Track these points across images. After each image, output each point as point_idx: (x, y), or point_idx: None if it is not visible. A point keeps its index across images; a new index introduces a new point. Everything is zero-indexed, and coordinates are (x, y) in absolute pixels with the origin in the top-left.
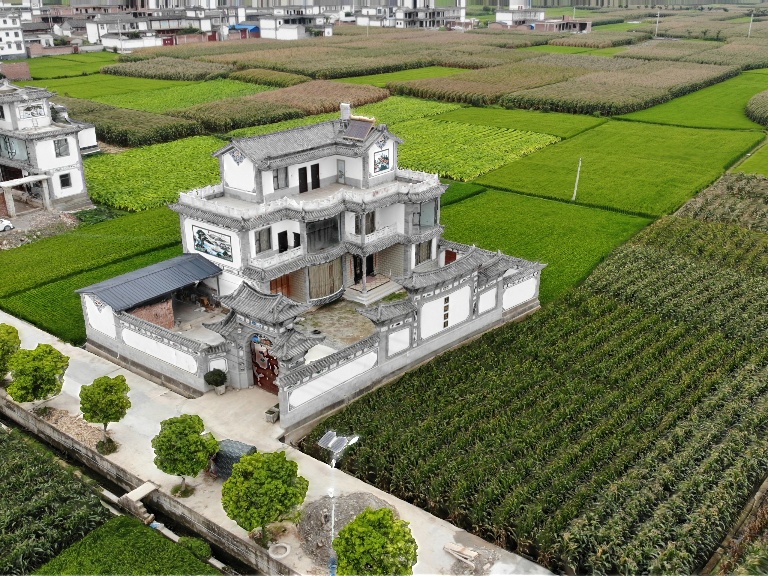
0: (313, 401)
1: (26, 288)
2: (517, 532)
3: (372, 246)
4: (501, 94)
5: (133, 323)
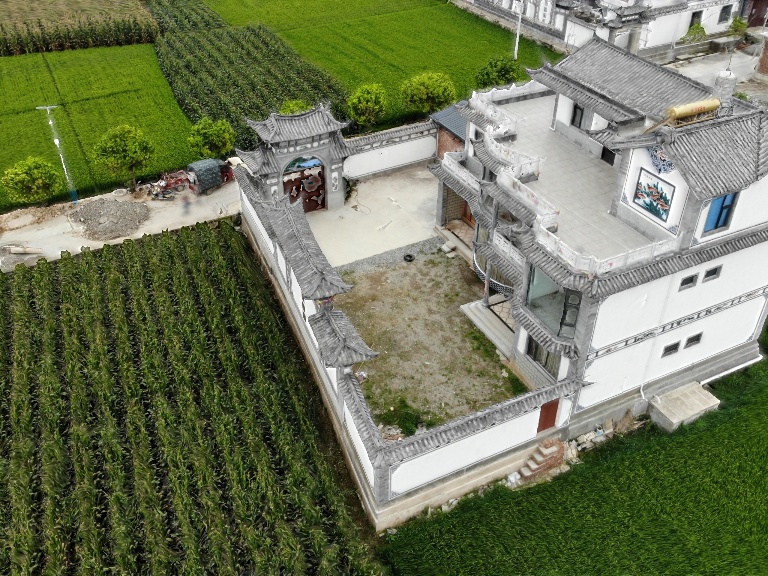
0: None
1: None
2: None
3: (495, 253)
4: None
5: None
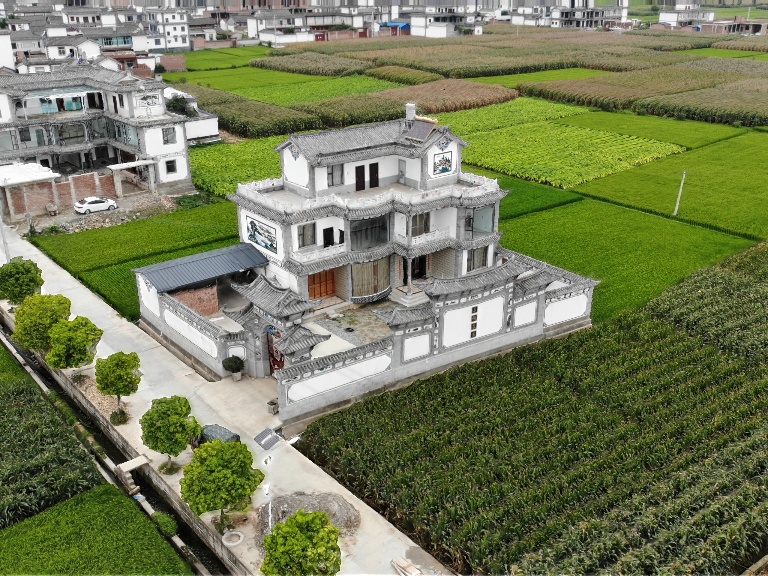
0: (315, 397)
1: (109, 264)
2: (473, 557)
3: (419, 248)
4: (635, 99)
5: (170, 305)
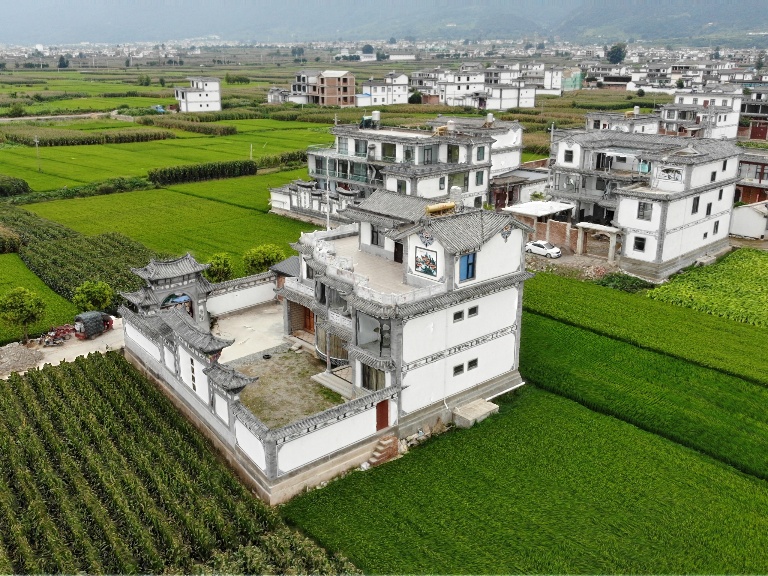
0: (134, 343)
1: None
2: None
3: (331, 326)
4: None
5: None
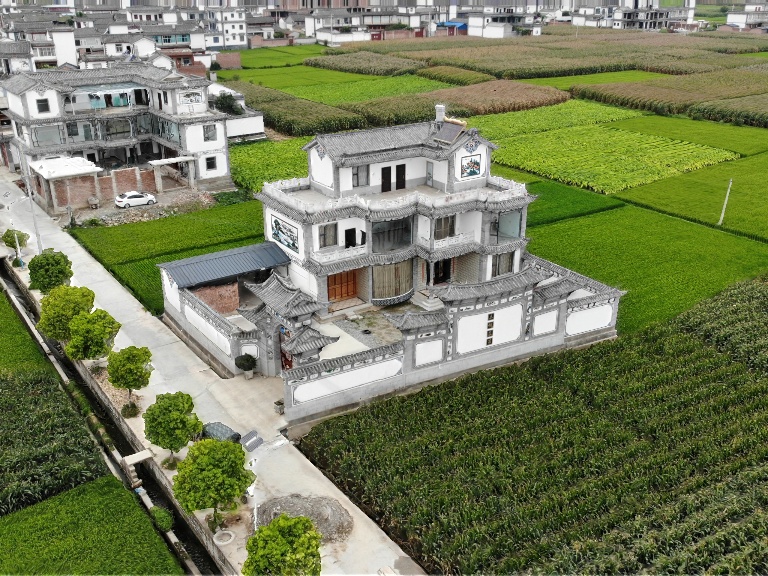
0: (322, 399)
1: (142, 258)
2: None
3: (441, 252)
4: (692, 103)
5: (189, 300)
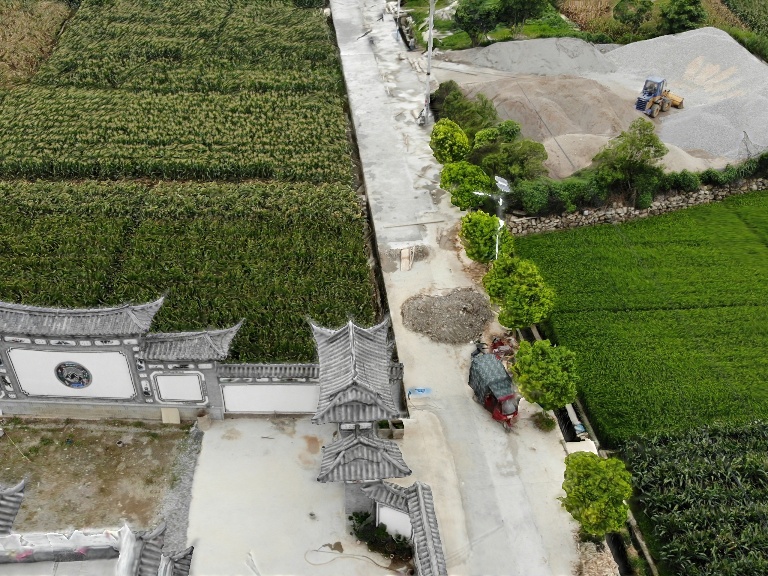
0: None
1: None
2: None
3: None
4: None
5: None
